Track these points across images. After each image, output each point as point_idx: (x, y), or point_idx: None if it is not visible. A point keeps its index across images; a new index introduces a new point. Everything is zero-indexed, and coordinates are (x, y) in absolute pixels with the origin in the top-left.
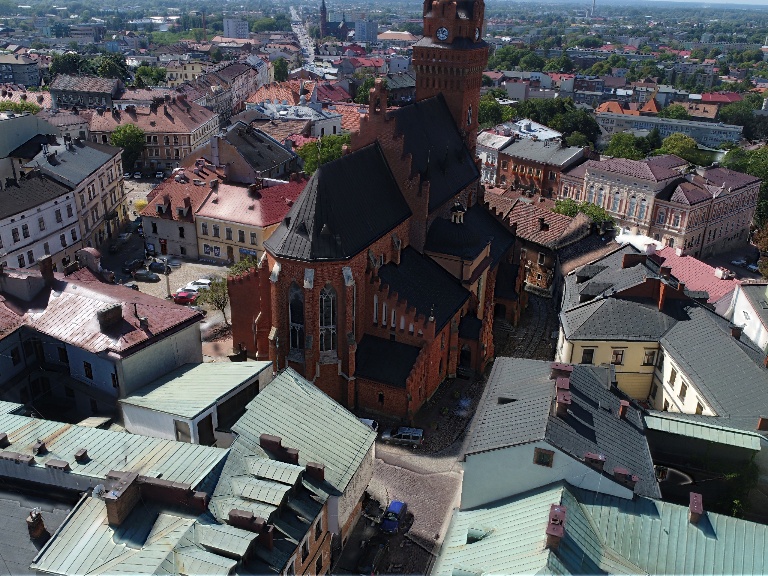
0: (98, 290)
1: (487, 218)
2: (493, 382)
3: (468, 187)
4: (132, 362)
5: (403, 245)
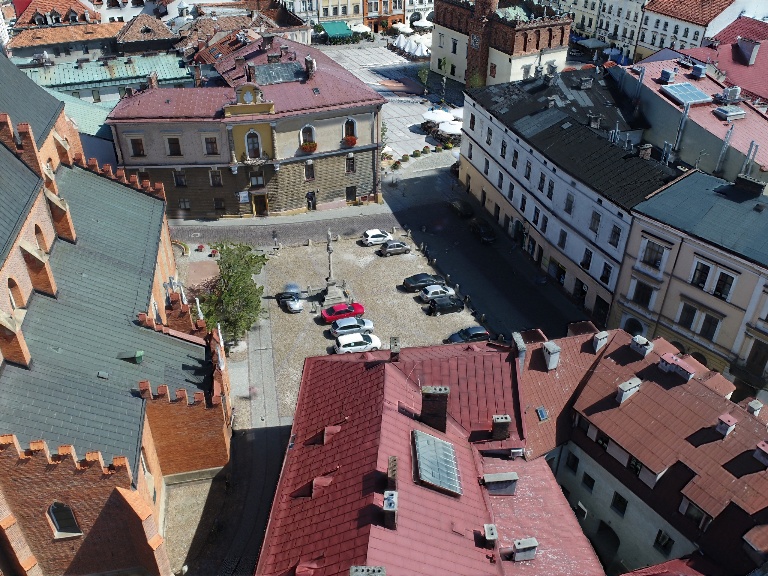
0: (201, 91)
1: None
2: None
3: None
4: None
5: None
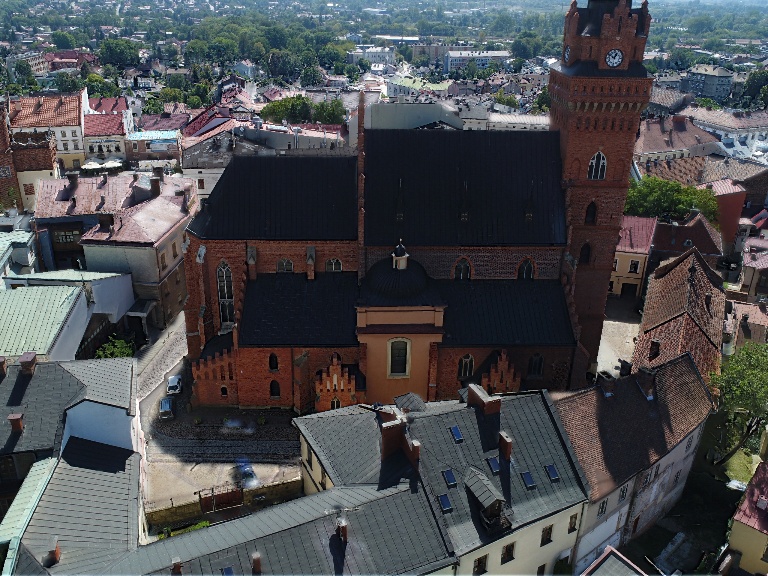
0: (151, 207)
1: (556, 302)
2: None
3: (517, 249)
4: (92, 251)
5: (343, 267)
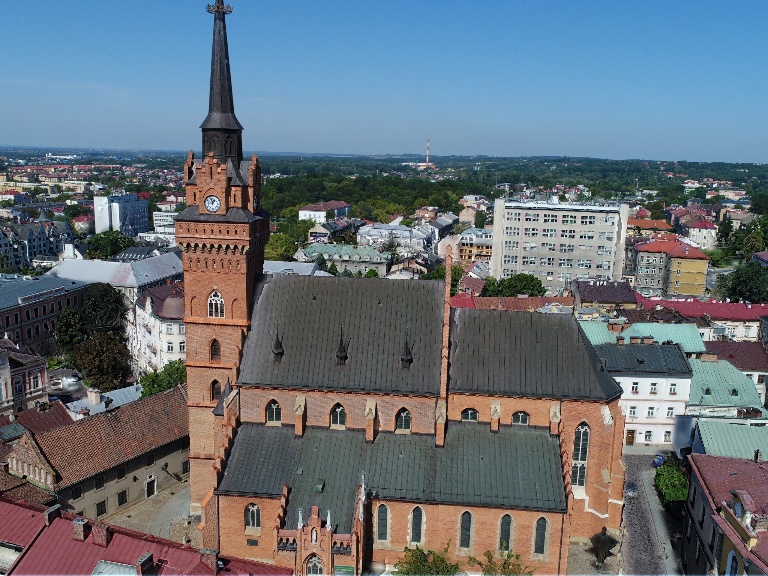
0: (766, 488)
1: None
2: (620, 369)
3: None
4: None
5: None
